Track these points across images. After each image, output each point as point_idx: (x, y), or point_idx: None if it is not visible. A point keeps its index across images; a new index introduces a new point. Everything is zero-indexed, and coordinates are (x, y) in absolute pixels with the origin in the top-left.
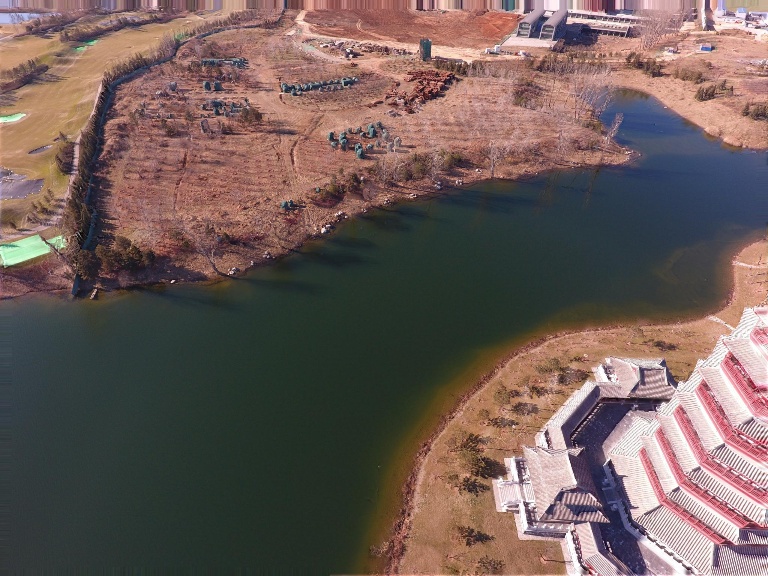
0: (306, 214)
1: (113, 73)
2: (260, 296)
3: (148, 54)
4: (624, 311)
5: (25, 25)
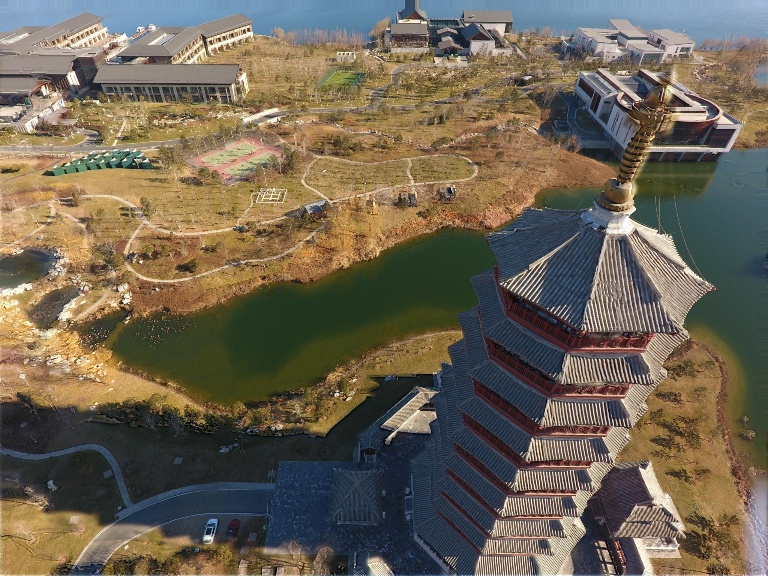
0: None
1: None
2: None
3: None
4: None
5: None
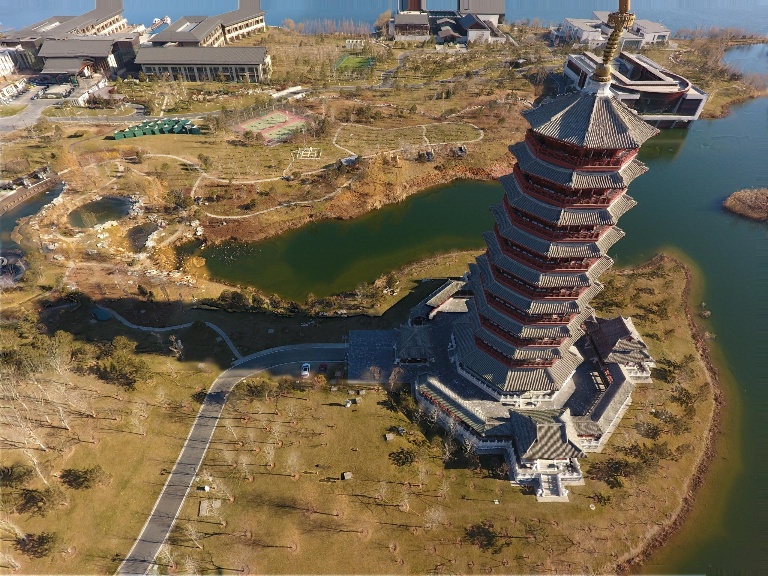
0: None
1: None
2: None
3: None
4: None
5: None
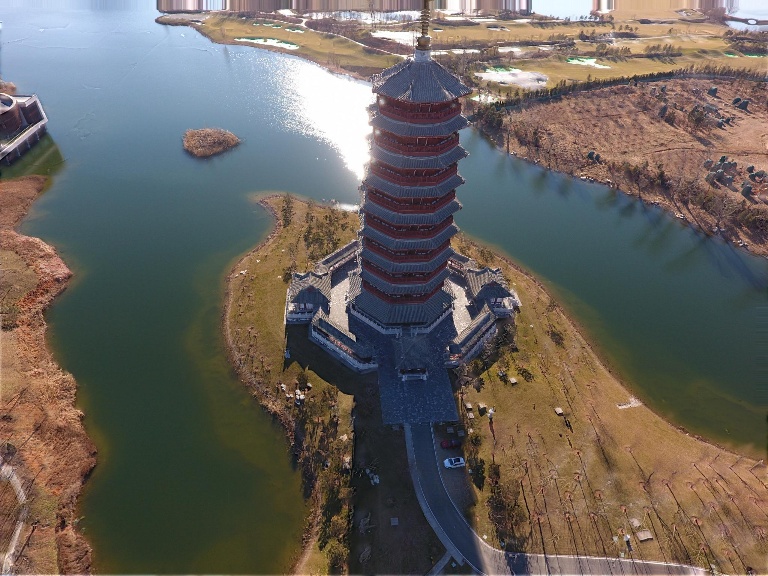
0: (593, 166)
1: (695, 68)
2: (499, 166)
3: (752, 70)
4: (603, 335)
5: (727, 31)
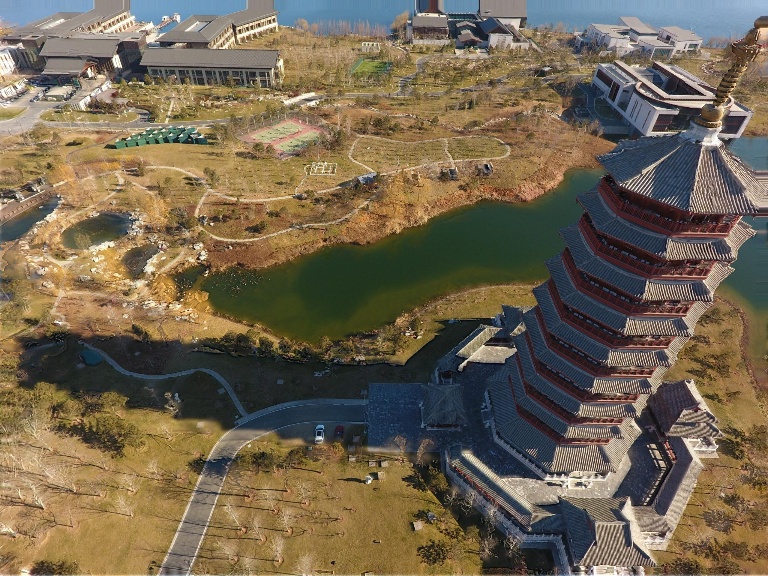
0: None
1: None
2: None
3: None
4: None
5: None
